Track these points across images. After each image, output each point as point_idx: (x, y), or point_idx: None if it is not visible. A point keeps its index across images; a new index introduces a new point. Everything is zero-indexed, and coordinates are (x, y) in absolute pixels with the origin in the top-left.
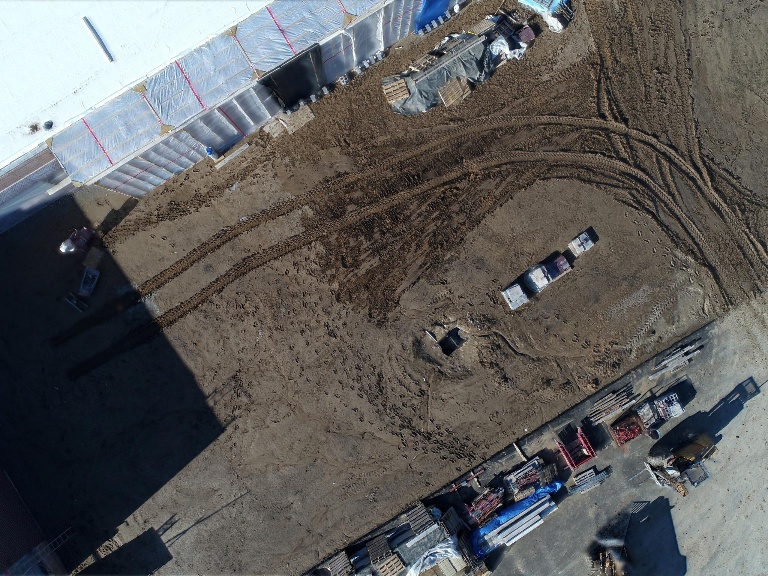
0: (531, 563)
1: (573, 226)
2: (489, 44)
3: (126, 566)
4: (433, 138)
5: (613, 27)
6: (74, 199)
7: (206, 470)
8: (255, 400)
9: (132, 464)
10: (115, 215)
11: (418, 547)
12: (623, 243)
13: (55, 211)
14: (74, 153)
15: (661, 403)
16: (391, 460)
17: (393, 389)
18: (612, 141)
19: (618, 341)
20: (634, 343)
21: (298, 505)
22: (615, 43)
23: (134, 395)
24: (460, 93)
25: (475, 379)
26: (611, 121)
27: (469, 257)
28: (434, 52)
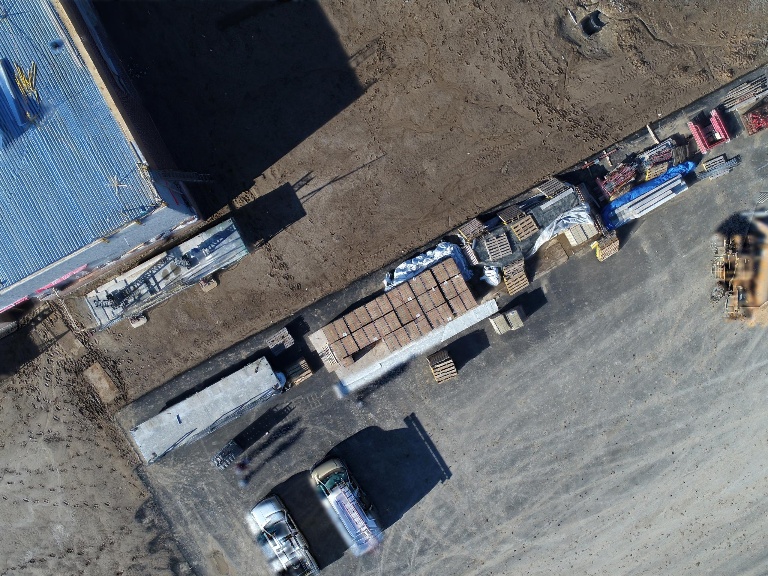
0: (656, 245)
1: None
2: None
3: (260, 218)
4: None
5: None
6: None
7: (344, 130)
8: (397, 64)
9: (273, 118)
10: None
11: (552, 210)
12: None
13: None
14: None
15: None
16: (526, 135)
17: (532, 64)
18: None
19: (755, 34)
20: None
21: (432, 172)
22: None
23: (279, 50)
24: None
25: (613, 61)
26: None
27: None
28: None
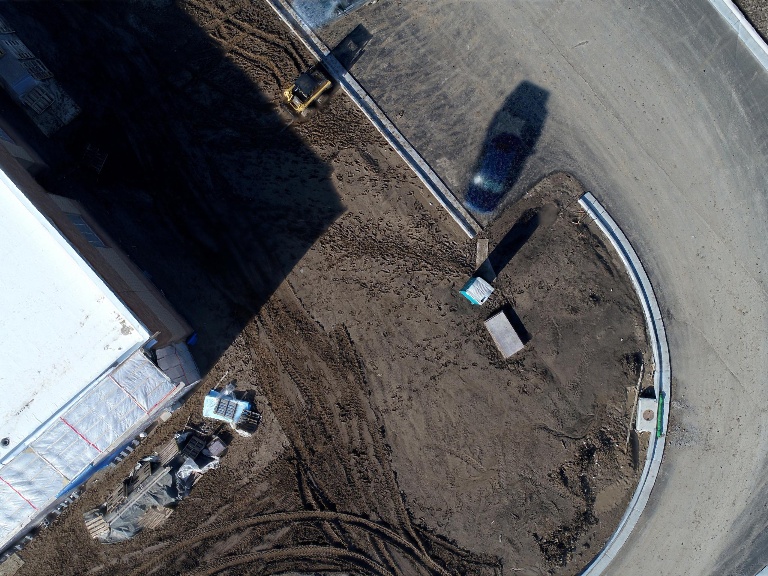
0: None
1: None
2: (177, 471)
3: None
4: (146, 559)
5: (303, 421)
6: None
7: None
8: None
9: None
10: None
11: None
12: None
13: None
14: None
15: None
16: None
17: None
18: (323, 528)
19: None
20: None
21: None
22: (308, 435)
23: None
24: (161, 516)
25: None
26: (318, 511)
27: None
28: (130, 479)
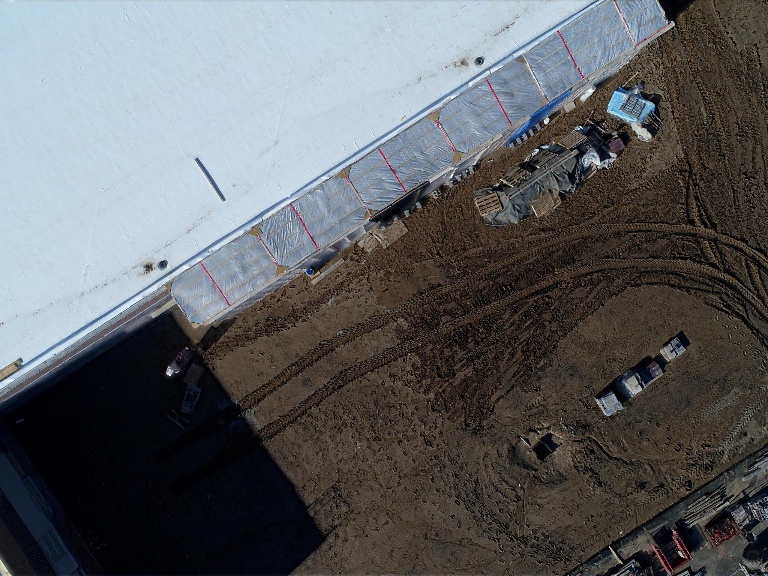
0: None
1: (664, 331)
2: (581, 157)
3: None
4: (525, 248)
5: (701, 134)
6: (174, 317)
7: None
8: (354, 509)
9: (235, 575)
10: (214, 332)
11: None
12: (714, 347)
13: (155, 330)
14: (192, 296)
15: (755, 505)
16: (488, 565)
17: (489, 495)
18: (701, 246)
19: (710, 443)
20: (726, 445)
21: None
22: (703, 150)
23: (236, 507)
24: (552, 204)
25: (570, 484)
26: (700, 227)
27: (562, 364)
28: (525, 164)
